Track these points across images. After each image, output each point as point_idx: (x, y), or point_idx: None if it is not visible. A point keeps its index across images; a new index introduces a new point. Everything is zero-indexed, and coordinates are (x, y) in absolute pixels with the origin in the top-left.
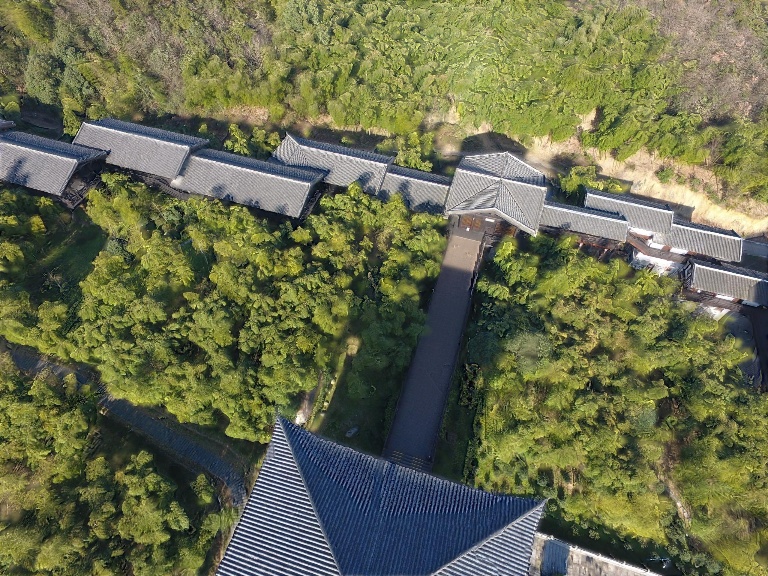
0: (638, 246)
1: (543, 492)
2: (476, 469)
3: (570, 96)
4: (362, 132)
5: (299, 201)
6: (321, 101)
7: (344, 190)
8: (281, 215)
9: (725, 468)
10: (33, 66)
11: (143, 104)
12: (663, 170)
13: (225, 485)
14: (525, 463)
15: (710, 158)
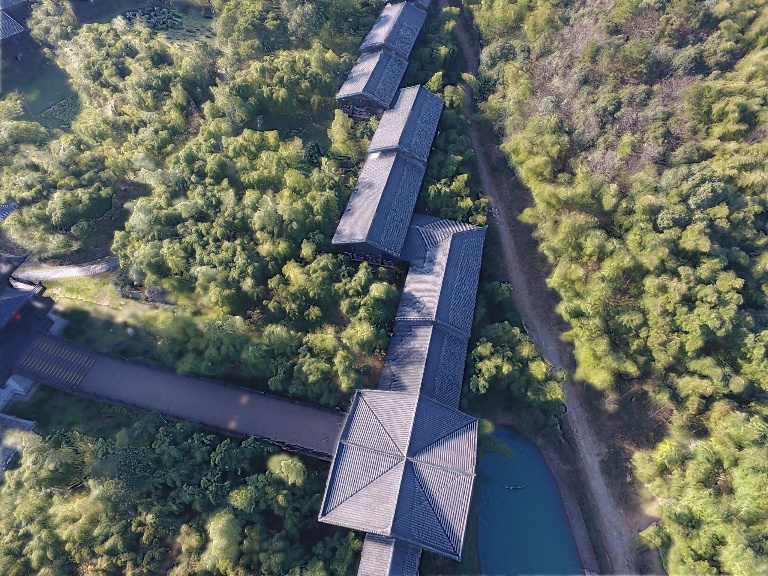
0: None
1: None
2: (65, 441)
3: None
4: None
5: (348, 238)
6: (572, 253)
7: (400, 287)
8: (335, 231)
9: None
10: (493, 45)
11: (498, 120)
12: None
13: (115, 257)
14: None
15: None
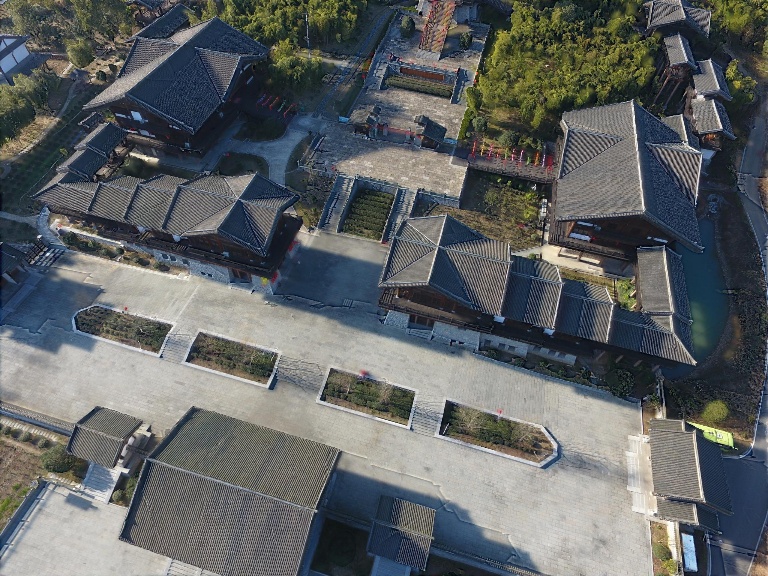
0: (687, 104)
1: None
2: None
3: None
4: None
5: None
6: None
7: None
8: None
9: None
10: None
11: None
12: None
13: None
14: None
15: None
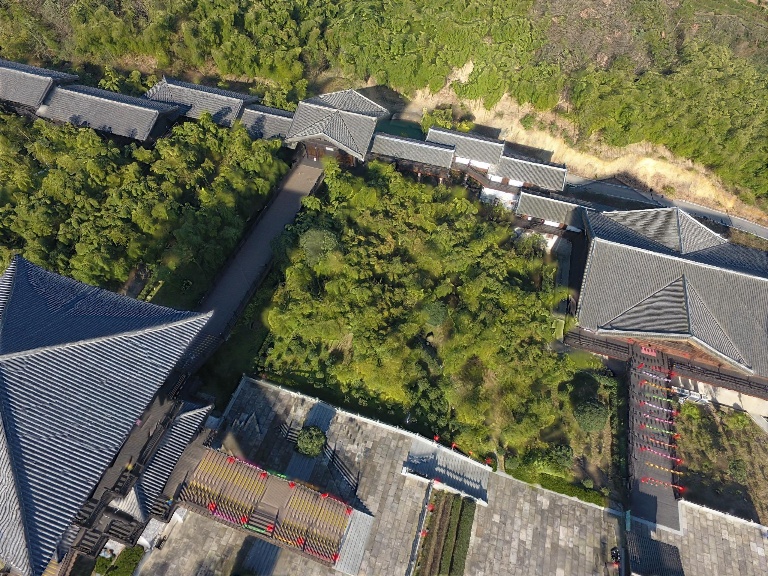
0: (478, 178)
1: (326, 369)
2: (268, 349)
3: (443, 49)
4: (253, 83)
5: (147, 126)
6: (207, 51)
7: None
8: (130, 138)
9: (480, 346)
10: None
11: (36, 50)
12: (525, 117)
13: None
14: (318, 347)
15: (571, 107)
